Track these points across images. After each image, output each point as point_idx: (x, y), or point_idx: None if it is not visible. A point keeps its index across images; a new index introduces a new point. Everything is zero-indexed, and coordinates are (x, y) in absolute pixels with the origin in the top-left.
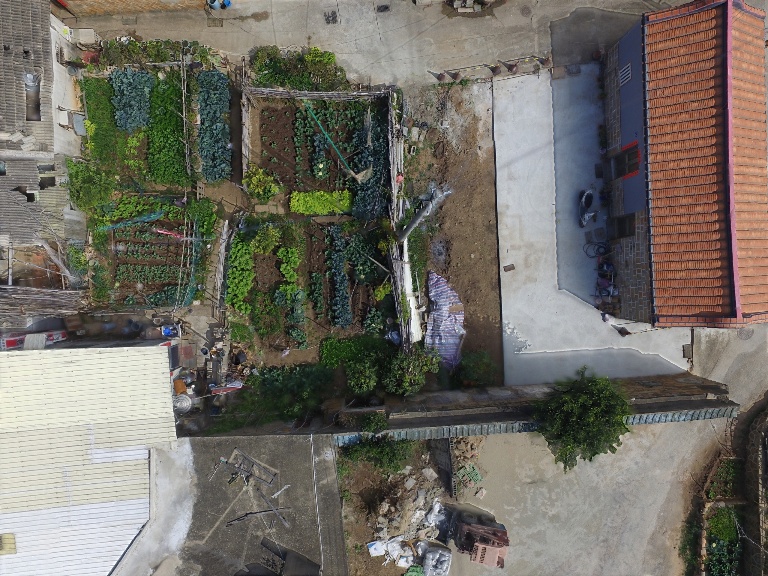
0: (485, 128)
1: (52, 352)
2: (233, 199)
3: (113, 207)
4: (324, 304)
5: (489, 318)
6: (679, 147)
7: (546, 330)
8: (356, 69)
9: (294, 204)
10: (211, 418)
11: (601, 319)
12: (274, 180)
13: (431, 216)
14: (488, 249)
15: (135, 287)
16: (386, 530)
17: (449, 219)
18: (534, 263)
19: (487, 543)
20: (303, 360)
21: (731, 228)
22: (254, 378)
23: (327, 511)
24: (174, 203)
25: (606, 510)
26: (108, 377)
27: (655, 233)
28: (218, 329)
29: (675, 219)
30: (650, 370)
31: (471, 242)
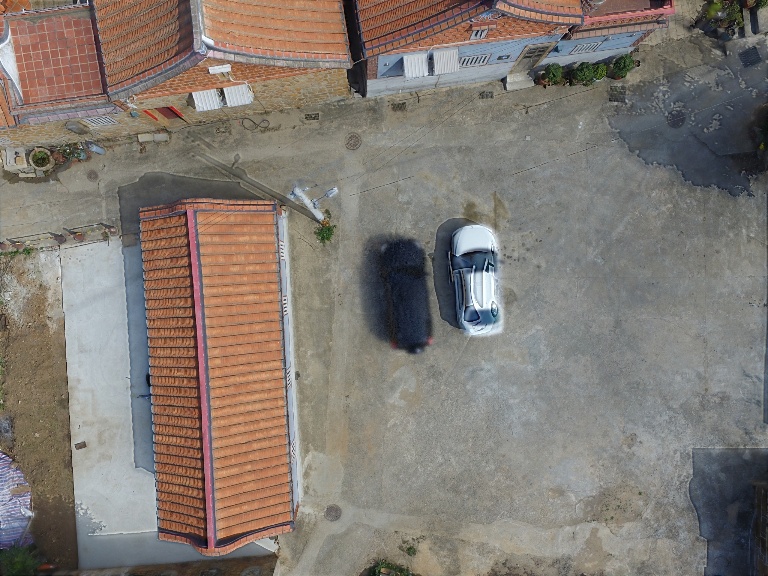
0: (55, 298)
1: None
2: None
3: None
4: None
5: (61, 498)
6: (170, 354)
7: (122, 510)
8: None
9: None
10: None
11: None
12: None
13: None
14: (60, 425)
15: None
16: None
17: (11, 396)
18: (108, 440)
19: None
20: None
21: (203, 451)
22: None
23: None
24: None
25: None
26: None
27: (157, 441)
28: None
29: (170, 430)
30: (235, 552)
31: (36, 420)
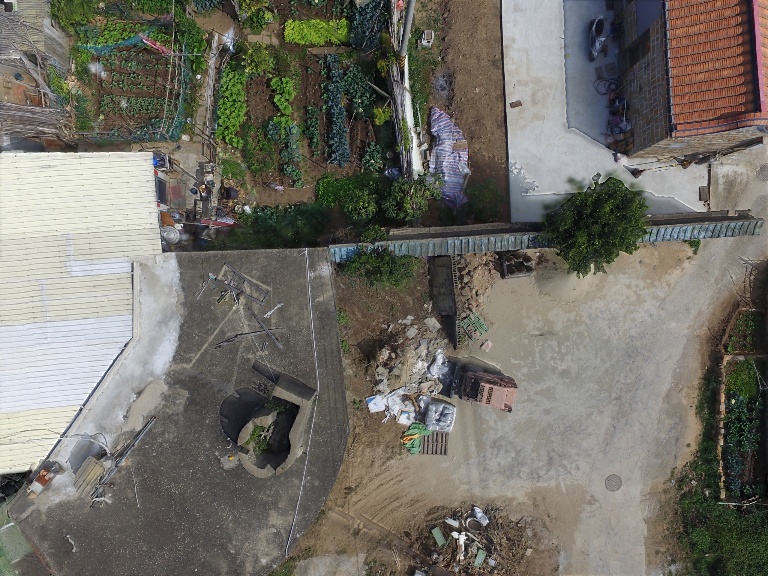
0: None
1: (29, 155)
2: (225, 30)
3: (97, 33)
4: (320, 141)
5: (495, 158)
6: None
7: (555, 171)
8: None
9: (289, 32)
10: (200, 250)
11: (613, 159)
12: (268, 9)
13: (433, 49)
14: (493, 85)
15: (121, 120)
16: (386, 382)
17: (452, 51)
18: (542, 100)
19: (494, 384)
20: (298, 200)
21: (754, 17)
22: (246, 215)
23: (323, 331)
24: (162, 31)
25: (619, 365)
26: (89, 184)
27: (672, 37)
28: (208, 164)
29: (693, 18)
30: (665, 214)
31: (476, 76)
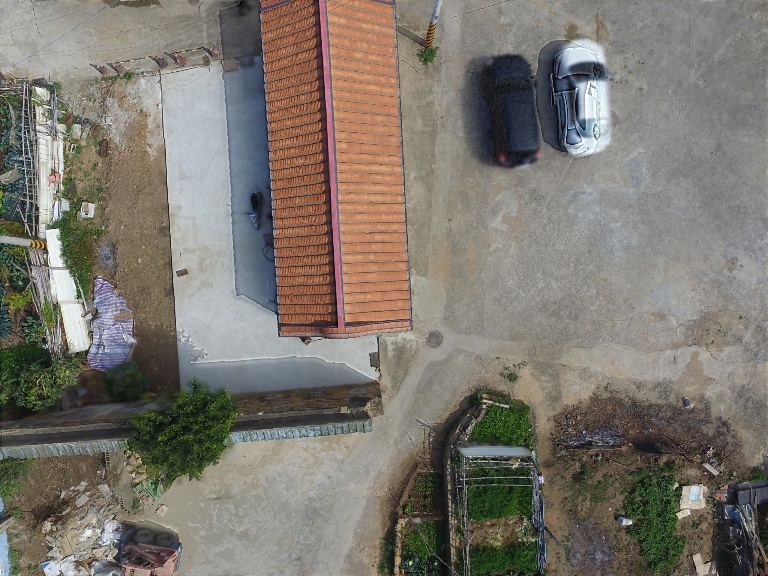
0: (155, 124)
1: None
2: None
3: None
4: None
5: (163, 326)
6: (293, 144)
7: (224, 338)
8: (12, 62)
9: None
10: None
11: None
12: None
13: (96, 218)
14: (161, 253)
15: None
16: (57, 549)
17: (114, 221)
18: (210, 267)
19: (138, 565)
20: None
21: (332, 231)
22: None
23: None
24: None
25: (298, 527)
26: None
27: (277, 236)
28: None
29: (292, 221)
30: (336, 380)
31: (138, 246)
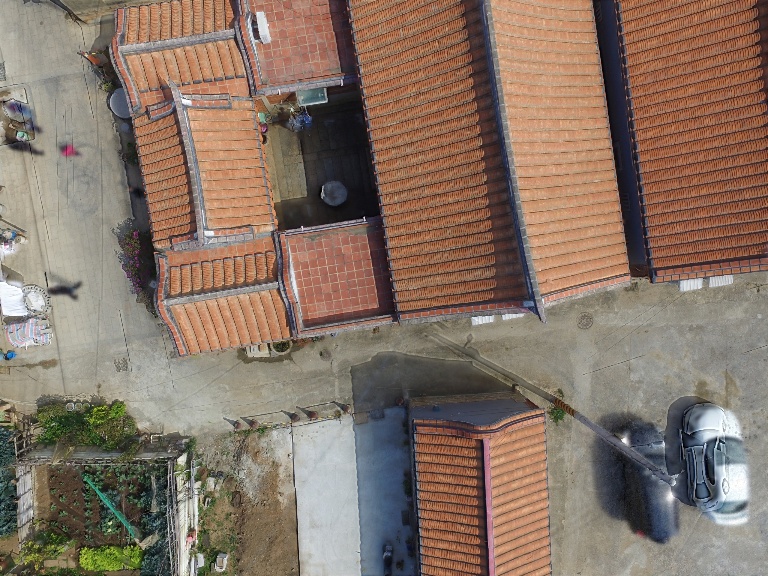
0: (286, 473)
1: None
2: None
3: None
4: None
5: None
6: (448, 566)
7: None
8: (148, 417)
9: (82, 562)
10: None
11: None
12: (64, 533)
13: (229, 568)
14: None
15: None
16: None
17: (246, 573)
18: None
19: None
20: None
21: None
22: None
23: None
24: None
25: None
26: None
27: None
28: None
29: None
30: None
31: None
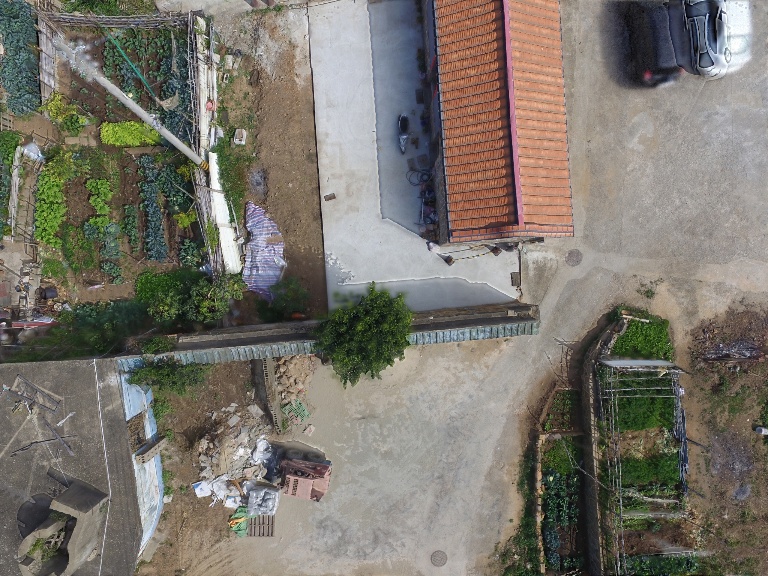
0: (302, 55)
1: None
2: (44, 132)
3: None
4: (140, 238)
5: (311, 249)
6: (465, 55)
7: (370, 260)
8: None
9: (103, 135)
10: None
11: (426, 248)
12: None
13: (248, 145)
14: (308, 179)
15: None
16: (210, 469)
17: (265, 148)
18: (356, 192)
19: (301, 475)
20: (119, 295)
21: (511, 133)
22: (65, 313)
23: (113, 438)
24: None
25: (440, 445)
26: None
27: (447, 146)
28: (27, 264)
29: (464, 130)
30: (479, 299)
31: (289, 171)
